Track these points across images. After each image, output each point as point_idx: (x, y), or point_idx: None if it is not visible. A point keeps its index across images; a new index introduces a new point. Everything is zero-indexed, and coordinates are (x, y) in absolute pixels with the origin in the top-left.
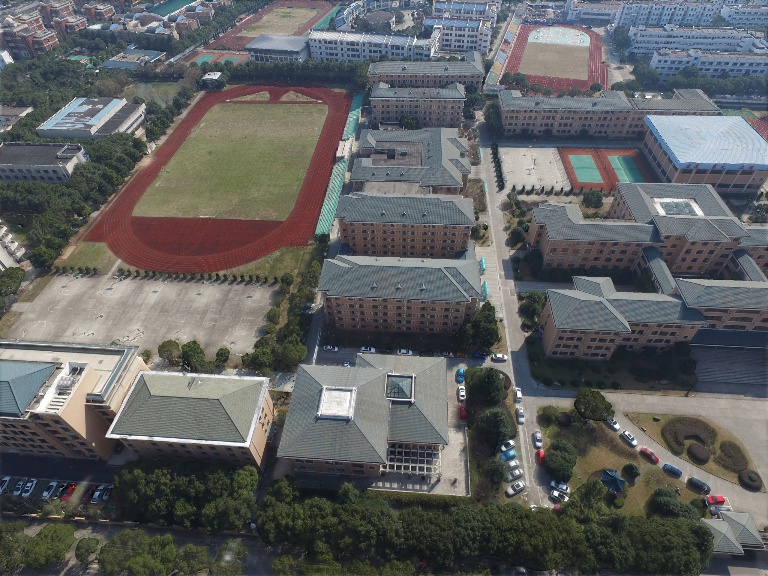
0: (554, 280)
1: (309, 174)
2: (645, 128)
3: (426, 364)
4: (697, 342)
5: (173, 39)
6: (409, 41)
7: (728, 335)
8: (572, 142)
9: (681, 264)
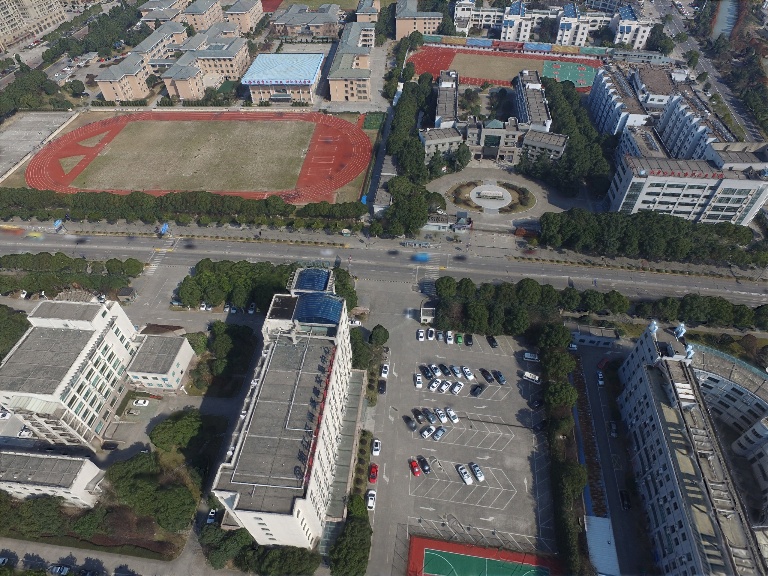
0: None
1: None
2: None
3: None
4: None
5: None
6: (463, 0)
7: None
8: None
9: None
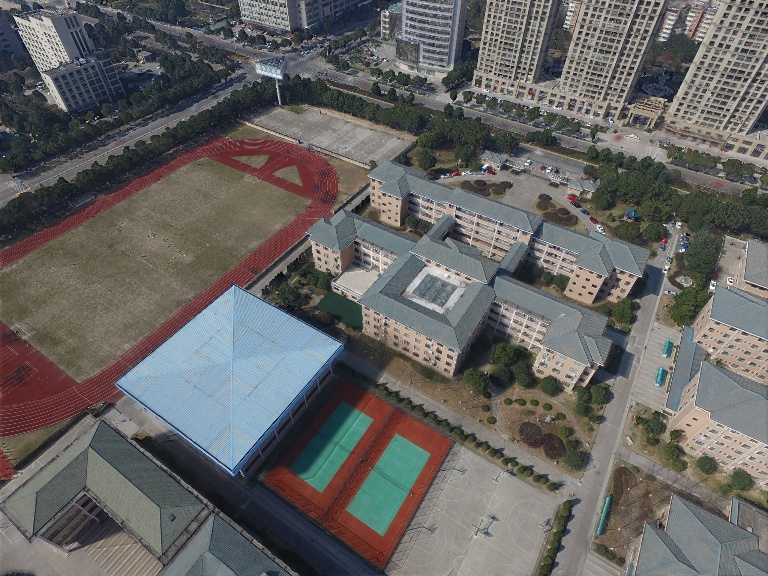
0: None
1: None
2: None
3: (767, 276)
4: None
5: None
6: None
7: None
8: (337, 575)
9: None
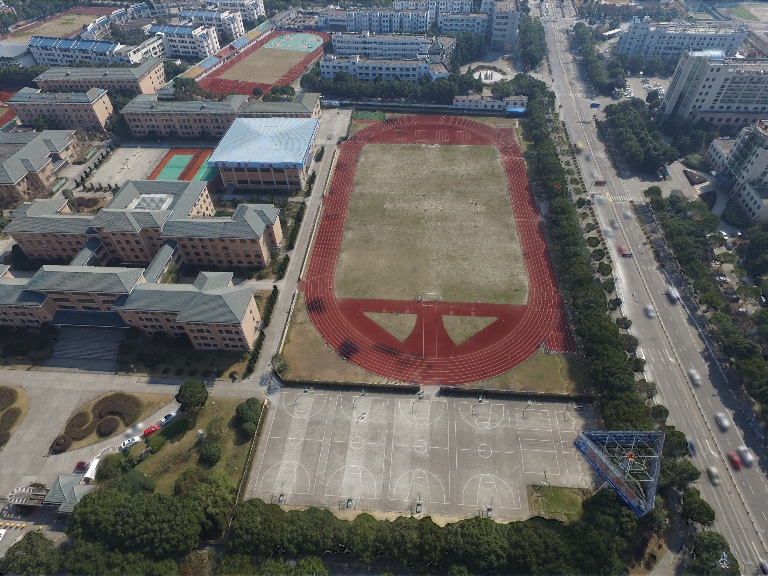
0: (26, 269)
1: None
2: None
3: None
4: (57, 322)
5: None
6: (111, 48)
7: (87, 315)
8: (191, 143)
9: (126, 253)
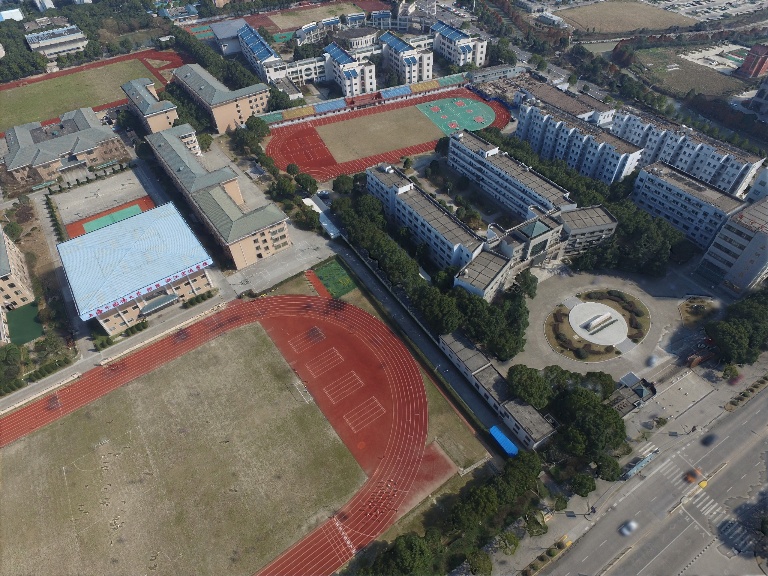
0: None
1: (42, 122)
2: (205, 222)
3: None
4: None
5: (209, 5)
6: (265, 58)
7: None
8: (167, 198)
9: None
